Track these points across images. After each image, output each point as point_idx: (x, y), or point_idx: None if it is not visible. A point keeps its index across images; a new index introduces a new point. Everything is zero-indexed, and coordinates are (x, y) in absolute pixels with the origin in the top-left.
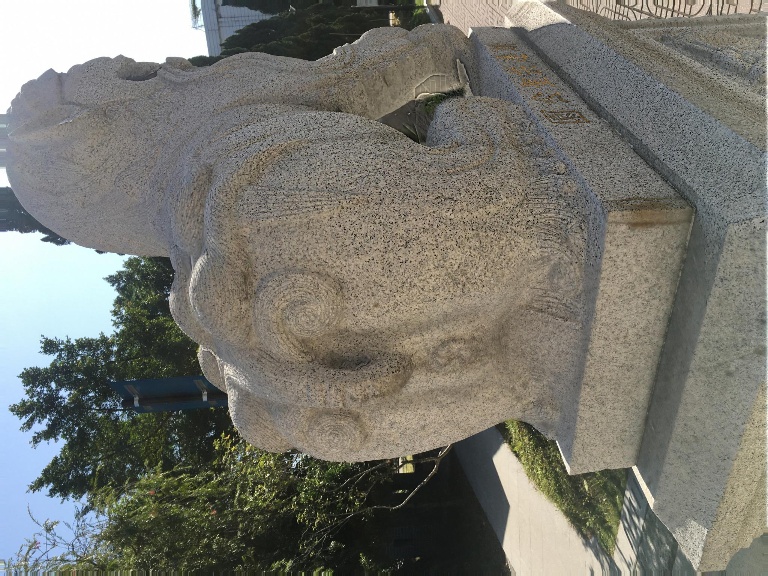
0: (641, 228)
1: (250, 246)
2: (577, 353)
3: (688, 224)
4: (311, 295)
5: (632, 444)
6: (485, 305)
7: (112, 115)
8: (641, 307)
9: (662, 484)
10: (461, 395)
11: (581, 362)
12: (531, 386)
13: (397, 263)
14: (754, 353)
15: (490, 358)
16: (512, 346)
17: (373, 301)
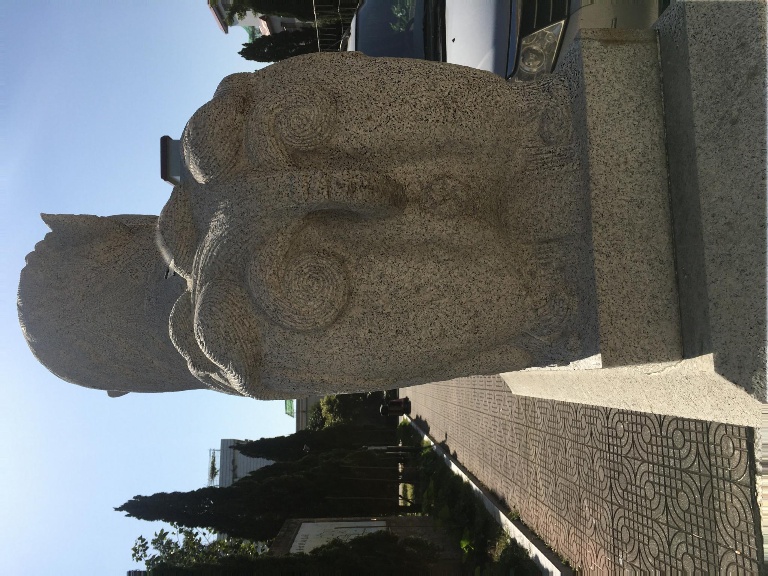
0: (613, 45)
1: (254, 88)
2: (580, 196)
3: (655, 44)
4: (306, 100)
5: (670, 320)
6: (478, 147)
7: (136, 231)
8: (633, 128)
9: (714, 320)
10: (460, 254)
11: (586, 200)
12: (540, 276)
13: (390, 83)
14: (748, 79)
15: (490, 226)
16: (513, 223)
17: (366, 114)
